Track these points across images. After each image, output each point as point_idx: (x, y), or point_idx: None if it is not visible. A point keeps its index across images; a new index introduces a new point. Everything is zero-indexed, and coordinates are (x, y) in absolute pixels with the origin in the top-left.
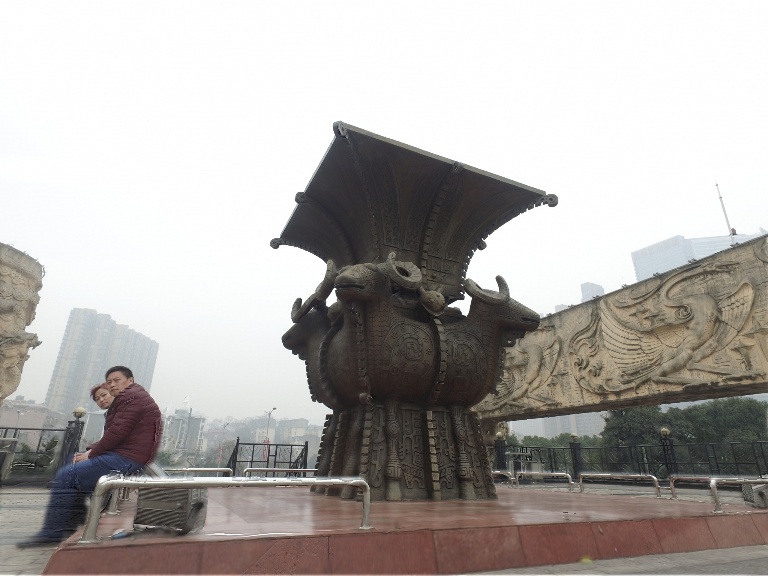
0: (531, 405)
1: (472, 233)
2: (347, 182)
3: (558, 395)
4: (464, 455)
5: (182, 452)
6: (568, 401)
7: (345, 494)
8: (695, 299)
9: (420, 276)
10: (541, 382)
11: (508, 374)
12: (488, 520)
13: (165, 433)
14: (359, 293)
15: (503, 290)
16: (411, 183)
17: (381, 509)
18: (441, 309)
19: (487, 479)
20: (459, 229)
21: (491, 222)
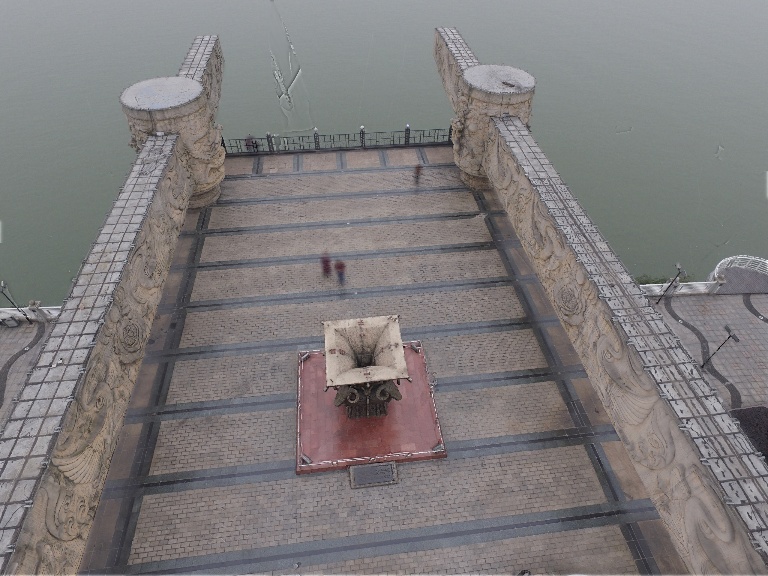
0: None
1: None
2: None
3: None
4: None
5: None
6: None
7: None
8: None
9: None
10: None
11: None
12: None
13: None
14: None
15: None
16: None
17: None
18: None
19: None
20: None
21: None
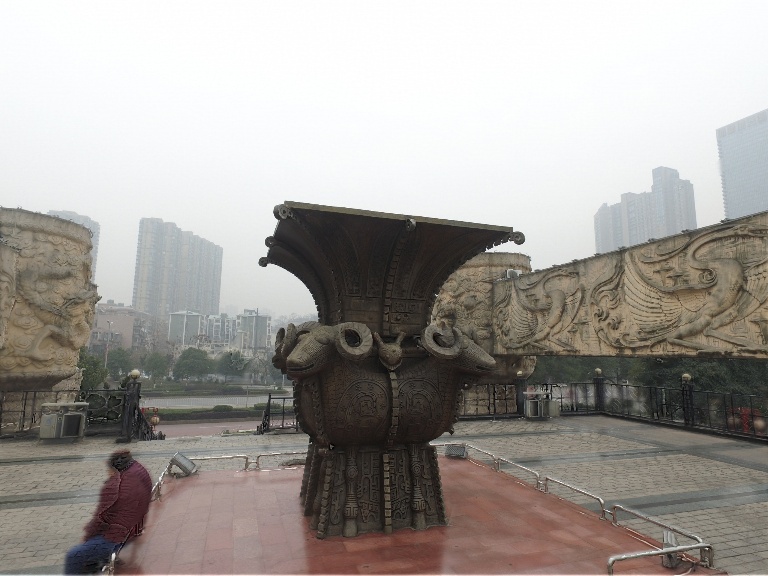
0: (552, 348)
1: (438, 271)
2: (306, 239)
3: (577, 342)
4: (418, 489)
5: (247, 360)
6: (586, 349)
7: (312, 525)
8: (721, 264)
9: (369, 345)
10: (562, 328)
11: (532, 316)
12: None
13: (230, 344)
14: (308, 373)
15: (457, 343)
16: (367, 238)
17: (320, 570)
18: (398, 362)
19: (439, 507)
20: (423, 270)
21: (457, 258)
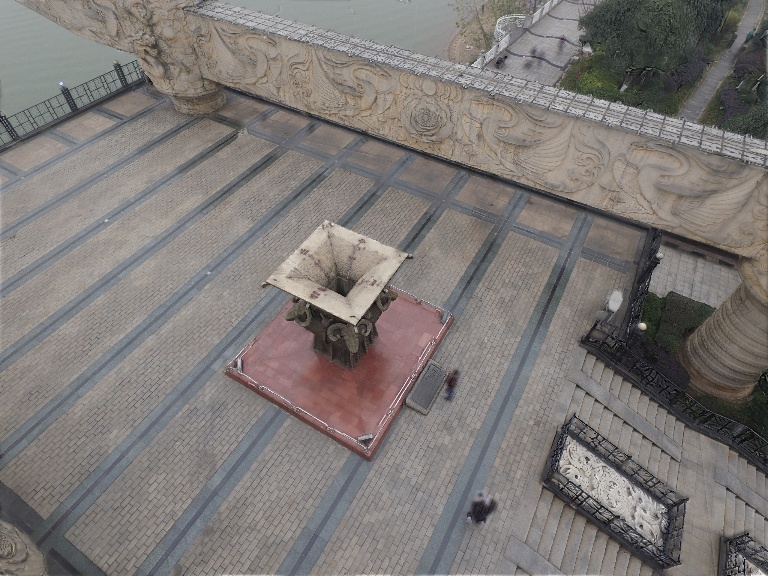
0: None
1: None
2: None
3: None
4: None
5: None
6: None
7: None
8: None
9: None
10: None
11: None
12: (299, 300)
13: None
14: None
15: None
16: None
17: None
18: None
19: None
20: None
21: None
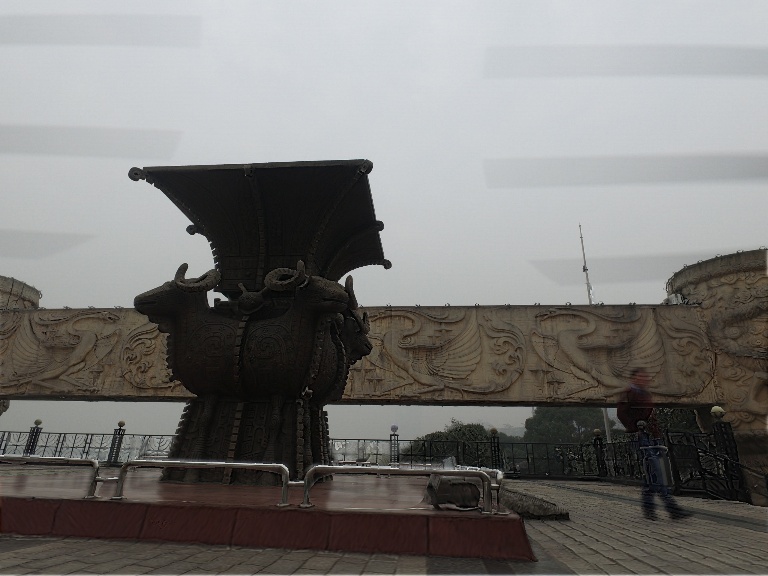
0: None
1: None
2: None
3: None
4: None
5: None
6: None
7: None
8: None
9: None
10: None
11: None
12: (105, 473)
13: None
14: None
15: None
16: None
17: None
18: None
19: None
20: None
21: None
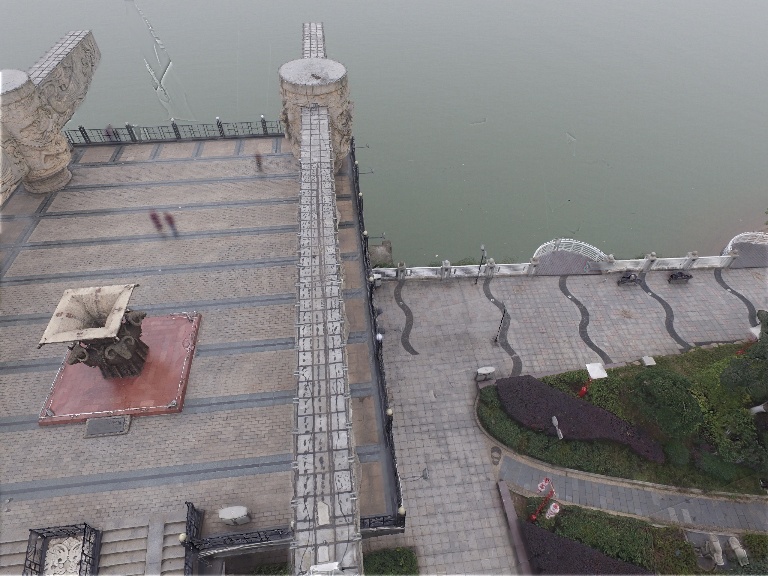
0: None
1: None
2: None
3: None
4: None
5: None
6: None
7: None
8: None
9: None
10: None
11: None
12: None
13: None
14: None
15: None
16: None
17: None
18: None
19: None
20: None
21: None
